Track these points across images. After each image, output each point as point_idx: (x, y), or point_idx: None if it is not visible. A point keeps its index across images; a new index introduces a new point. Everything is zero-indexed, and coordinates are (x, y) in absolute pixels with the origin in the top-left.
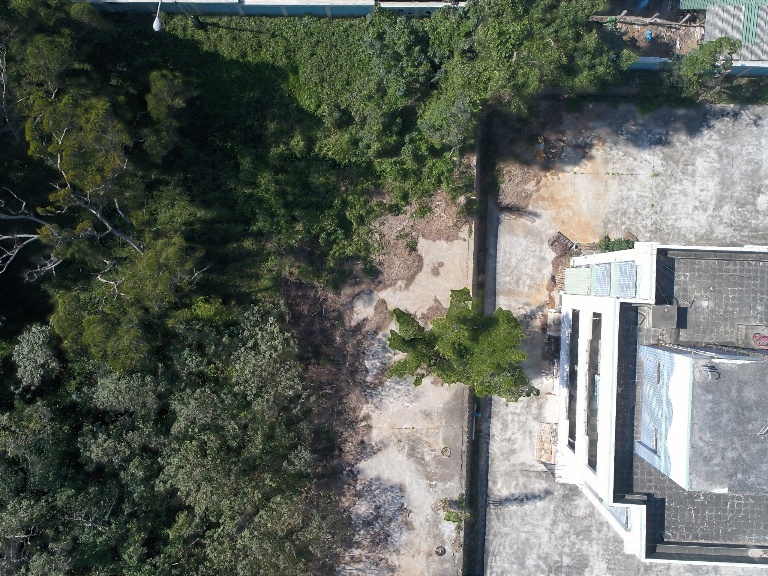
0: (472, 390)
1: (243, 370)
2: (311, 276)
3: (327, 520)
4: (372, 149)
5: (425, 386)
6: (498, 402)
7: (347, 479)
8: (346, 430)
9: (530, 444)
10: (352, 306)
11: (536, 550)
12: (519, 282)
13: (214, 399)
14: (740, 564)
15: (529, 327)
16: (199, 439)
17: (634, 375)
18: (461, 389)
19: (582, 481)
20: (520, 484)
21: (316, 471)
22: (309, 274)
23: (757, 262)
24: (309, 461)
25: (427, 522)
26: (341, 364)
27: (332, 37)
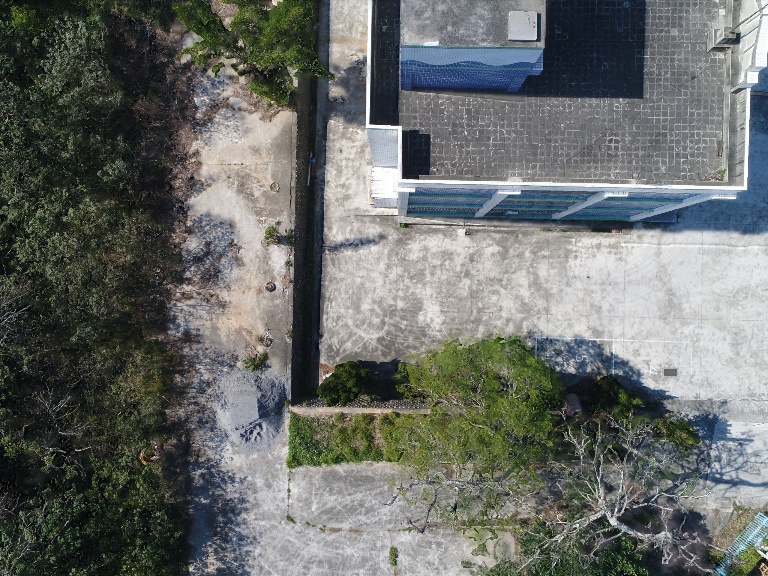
0: (306, 136)
1: (51, 71)
2: (138, 11)
3: (156, 254)
4: None
5: (253, 122)
6: (332, 148)
7: (177, 216)
8: (176, 167)
9: (364, 189)
10: (181, 44)
11: (371, 294)
12: (352, 29)
13: (16, 90)
14: (493, 182)
15: (362, 73)
16: (5, 136)
17: (398, 13)
18: (289, 125)
19: (396, 195)
20: (355, 229)
21: (141, 199)
22: (137, 9)
23: None
24: (124, 173)
25: (257, 258)
26: (171, 101)
27: None
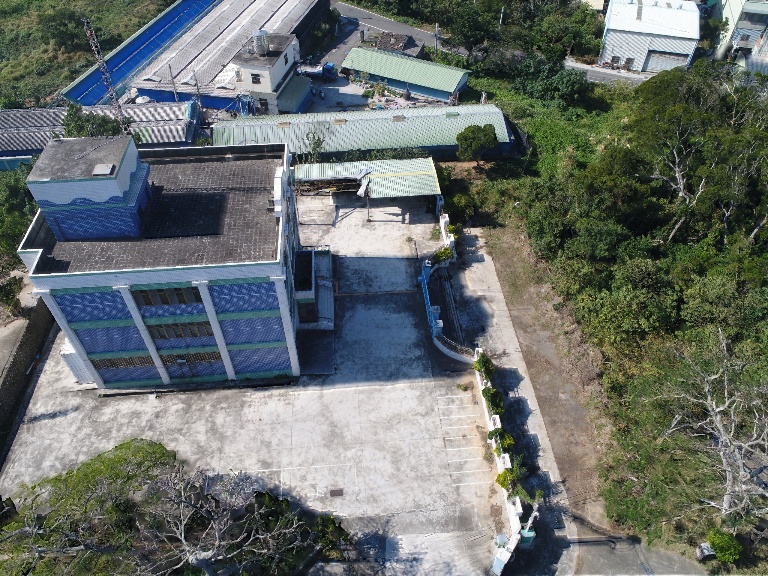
0: (37, 342)
1: None
2: None
3: None
4: (3, 208)
5: None
6: (57, 348)
7: None
8: None
9: None
10: None
11: (55, 453)
12: None
13: None
14: (99, 271)
15: None
16: None
17: None
18: (20, 328)
19: None
20: (57, 402)
21: None
22: None
23: (158, 165)
24: None
25: None
26: None
27: (5, 175)
